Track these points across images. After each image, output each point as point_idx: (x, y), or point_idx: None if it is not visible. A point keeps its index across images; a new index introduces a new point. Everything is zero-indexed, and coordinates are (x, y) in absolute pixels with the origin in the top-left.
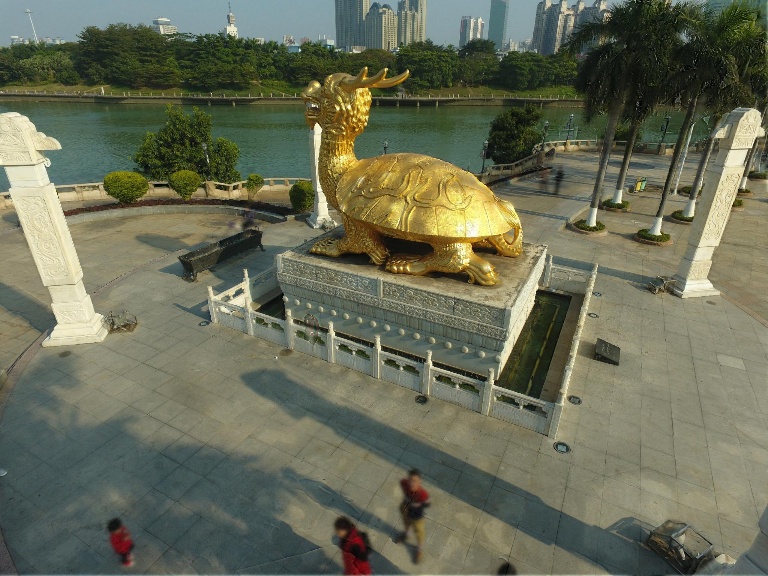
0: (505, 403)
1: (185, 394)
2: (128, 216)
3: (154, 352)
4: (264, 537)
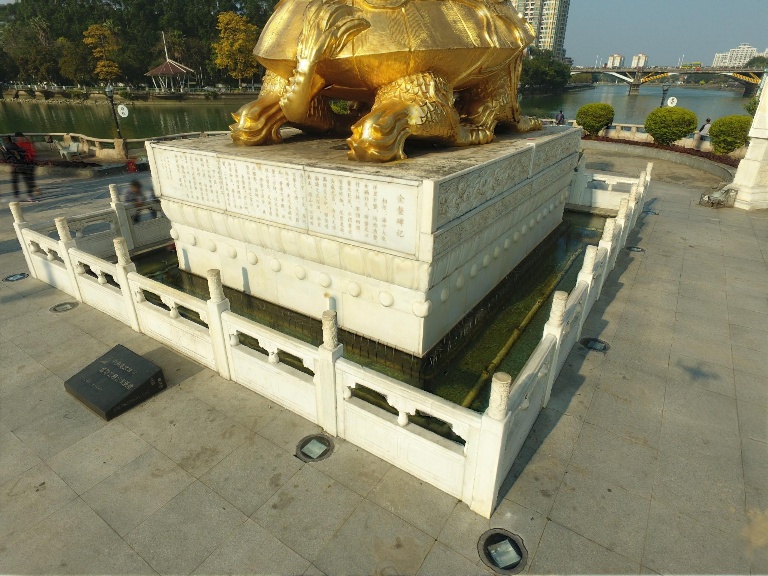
0: (101, 233)
1: None
2: (647, 156)
3: None
4: None
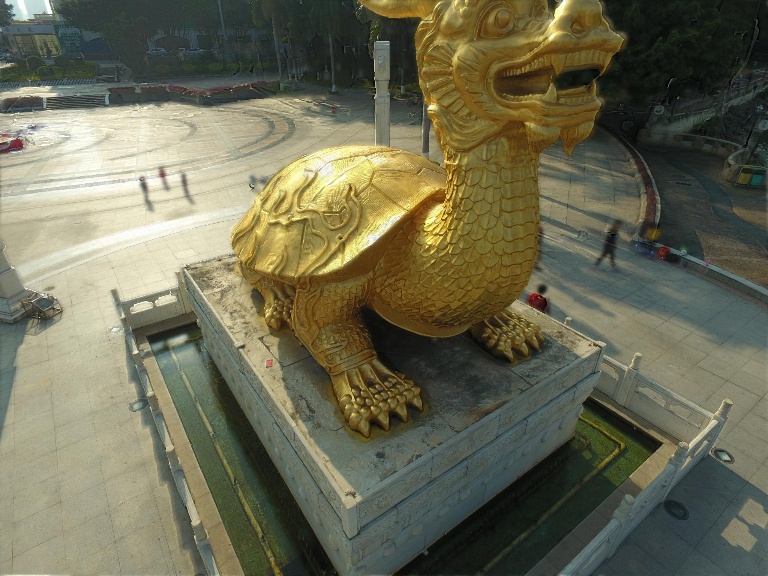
0: None
1: (667, 342)
2: None
3: (763, 413)
4: (564, 257)
